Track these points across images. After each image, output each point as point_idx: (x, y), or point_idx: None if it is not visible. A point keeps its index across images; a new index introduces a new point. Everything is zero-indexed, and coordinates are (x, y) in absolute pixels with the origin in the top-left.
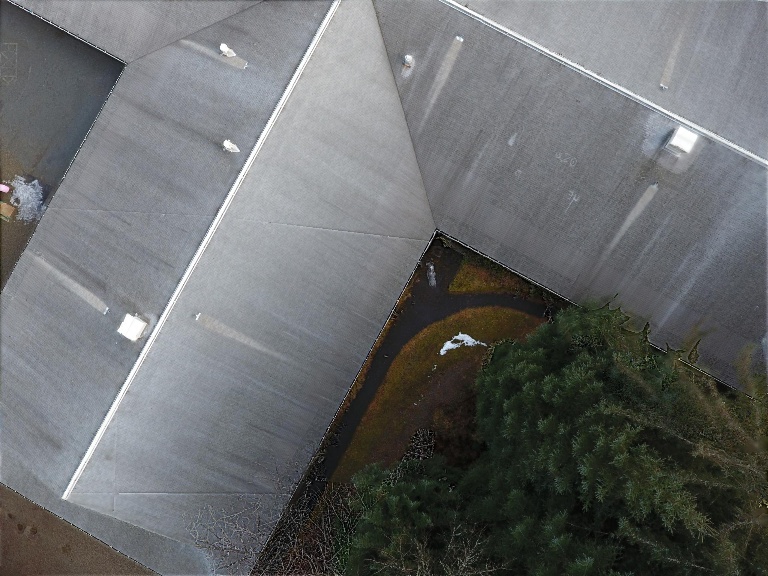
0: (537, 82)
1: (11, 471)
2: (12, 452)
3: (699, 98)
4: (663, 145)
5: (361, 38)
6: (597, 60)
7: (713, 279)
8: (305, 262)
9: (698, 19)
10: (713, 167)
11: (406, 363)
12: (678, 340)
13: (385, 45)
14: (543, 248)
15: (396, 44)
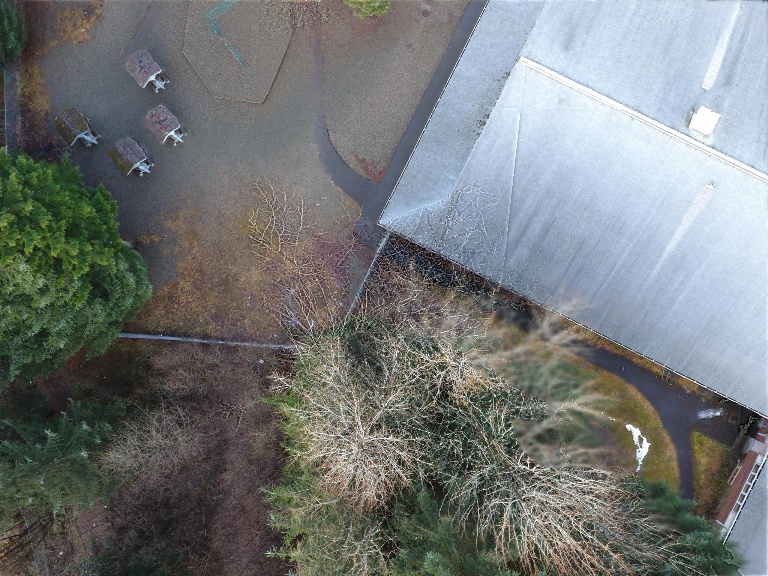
0: None
1: None
2: None
3: None
4: None
5: None
6: None
7: None
8: (761, 294)
9: None
10: None
11: (616, 390)
12: None
13: None
14: None
15: None
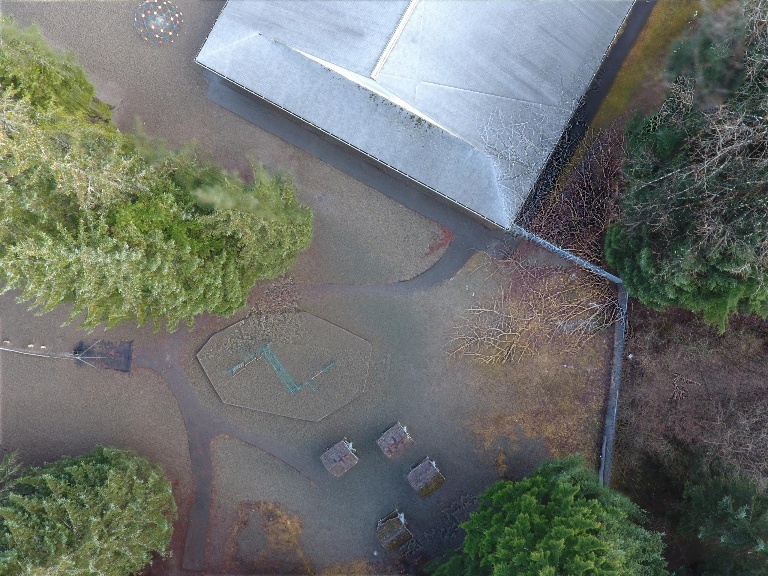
0: None
1: (290, 89)
2: (305, 51)
3: None
4: None
5: None
6: None
7: None
8: None
9: None
10: None
11: (667, 9)
12: None
13: None
14: None
15: None
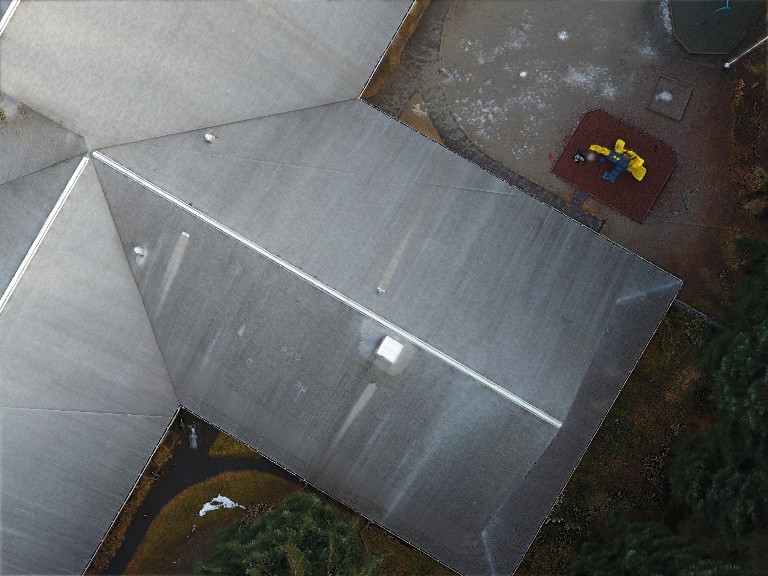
0: (259, 280)
1: None
2: None
3: (415, 302)
4: (378, 348)
5: (93, 228)
6: (317, 262)
7: (433, 474)
8: (38, 442)
9: (431, 215)
10: (424, 372)
11: (166, 523)
12: (406, 526)
13: (119, 234)
14: (278, 431)
15: (129, 234)
